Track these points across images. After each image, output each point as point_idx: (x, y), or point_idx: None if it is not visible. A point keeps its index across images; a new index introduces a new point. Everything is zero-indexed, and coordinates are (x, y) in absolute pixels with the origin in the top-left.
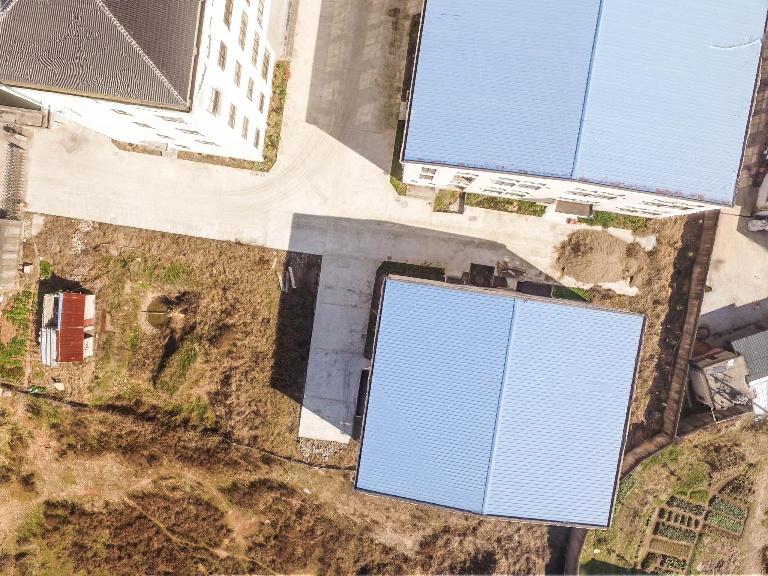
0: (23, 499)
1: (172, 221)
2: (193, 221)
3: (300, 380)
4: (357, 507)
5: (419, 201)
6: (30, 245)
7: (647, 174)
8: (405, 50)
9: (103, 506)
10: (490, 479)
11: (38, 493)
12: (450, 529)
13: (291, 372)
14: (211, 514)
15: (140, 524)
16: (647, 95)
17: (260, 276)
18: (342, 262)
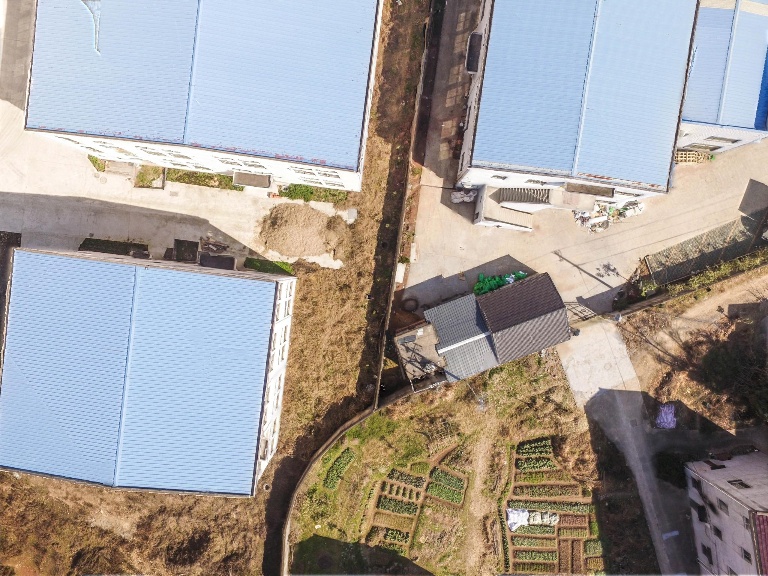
0: None
1: None
2: None
3: None
4: (69, 490)
5: (118, 177)
6: None
7: (255, 138)
8: (96, 24)
9: None
10: (120, 450)
11: None
12: (166, 509)
13: None
14: None
15: None
16: (251, 59)
17: None
18: (42, 240)
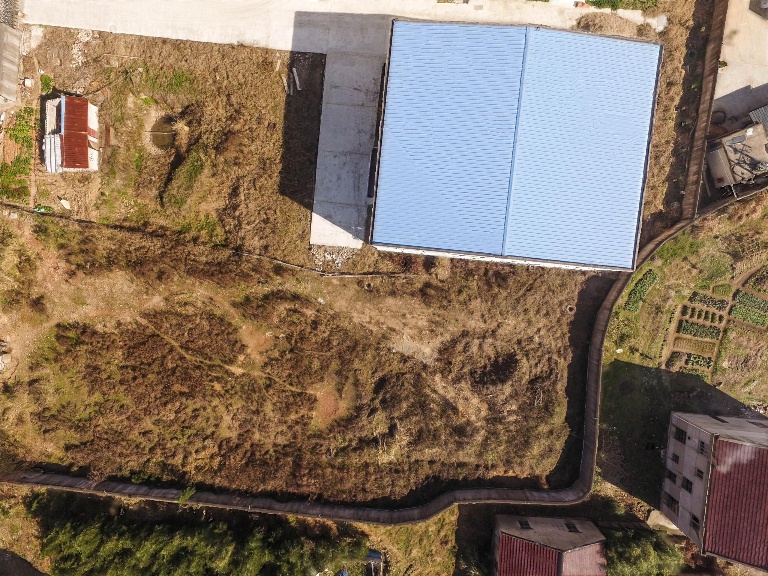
0: (34, 323)
1: (172, 26)
2: (194, 25)
3: (309, 185)
4: (373, 315)
5: None
6: (30, 58)
7: None
8: None
9: (115, 326)
10: (509, 218)
11: (49, 316)
12: (468, 333)
13: (300, 177)
14: (225, 329)
15: (153, 342)
16: None
17: (264, 79)
18: (347, 60)
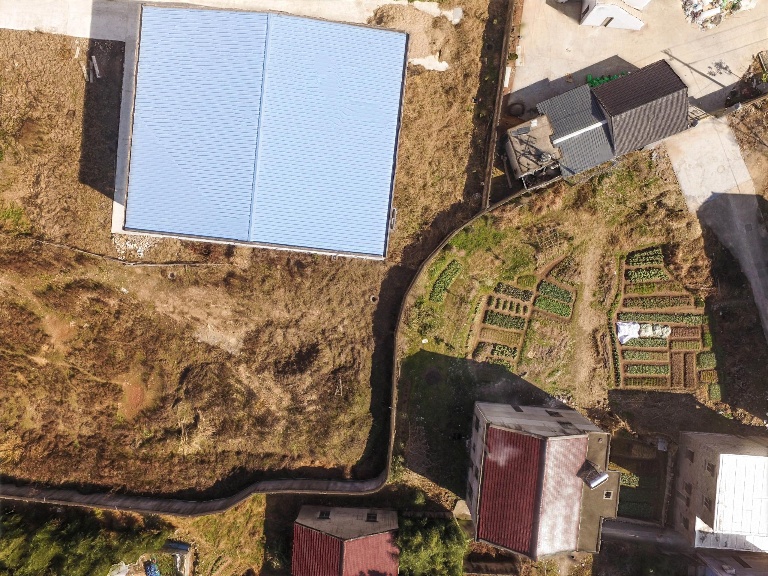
0: None
1: None
2: None
3: (110, 174)
4: (176, 304)
5: None
6: None
7: None
8: None
9: None
10: (254, 204)
11: None
12: (272, 323)
13: (100, 165)
14: (26, 318)
15: None
16: None
17: (62, 66)
18: None
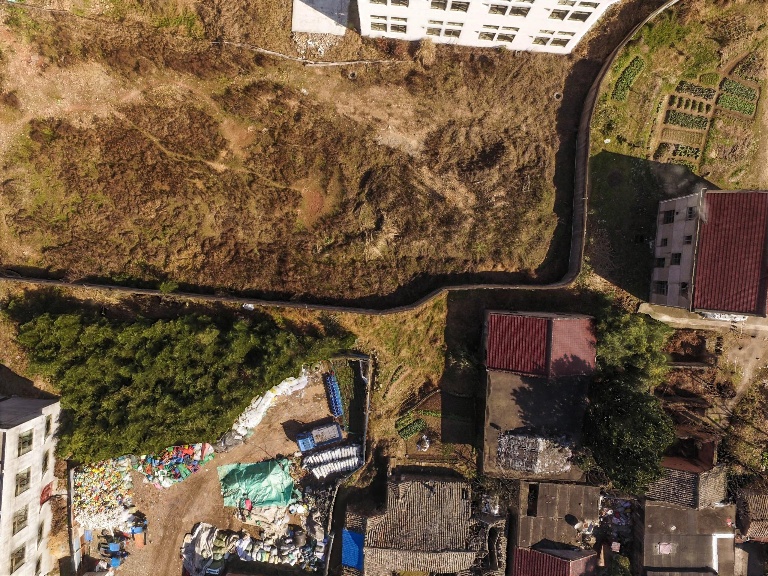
0: (7, 120)
1: None
2: None
3: None
4: (357, 105)
5: None
6: None
7: None
8: None
9: (92, 121)
10: None
11: (22, 111)
12: (455, 122)
13: None
14: (205, 122)
15: (132, 135)
16: None
17: None
18: None
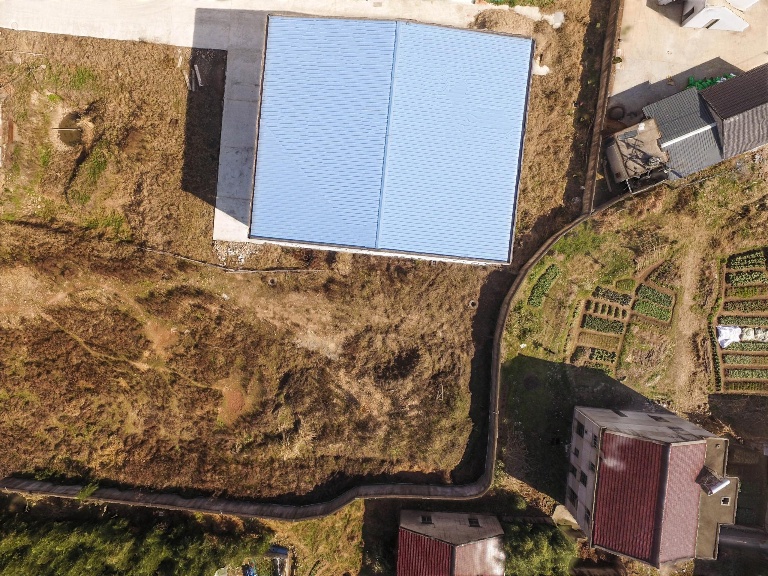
0: None
1: (74, 23)
2: (95, 22)
3: (212, 181)
4: (276, 310)
5: None
6: None
7: None
8: None
9: (19, 322)
10: (382, 211)
11: None
12: (372, 328)
13: (202, 173)
14: (129, 325)
15: (57, 338)
16: None
17: (166, 75)
18: (248, 56)
